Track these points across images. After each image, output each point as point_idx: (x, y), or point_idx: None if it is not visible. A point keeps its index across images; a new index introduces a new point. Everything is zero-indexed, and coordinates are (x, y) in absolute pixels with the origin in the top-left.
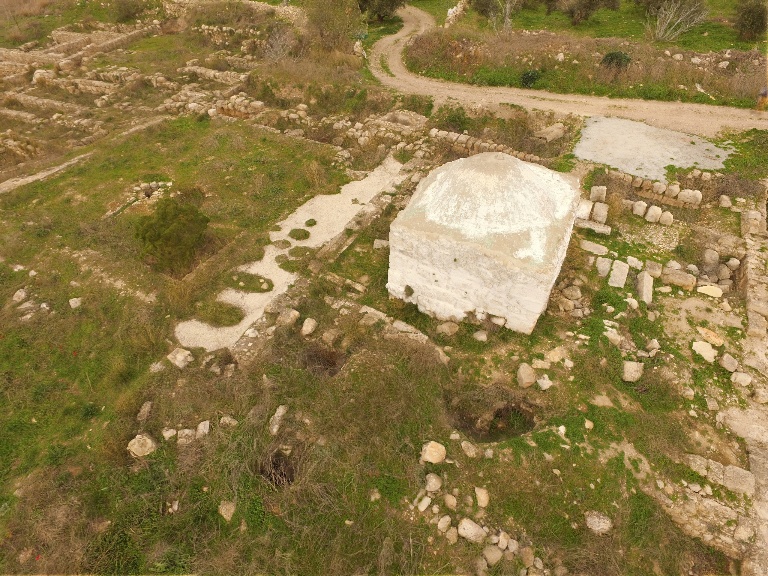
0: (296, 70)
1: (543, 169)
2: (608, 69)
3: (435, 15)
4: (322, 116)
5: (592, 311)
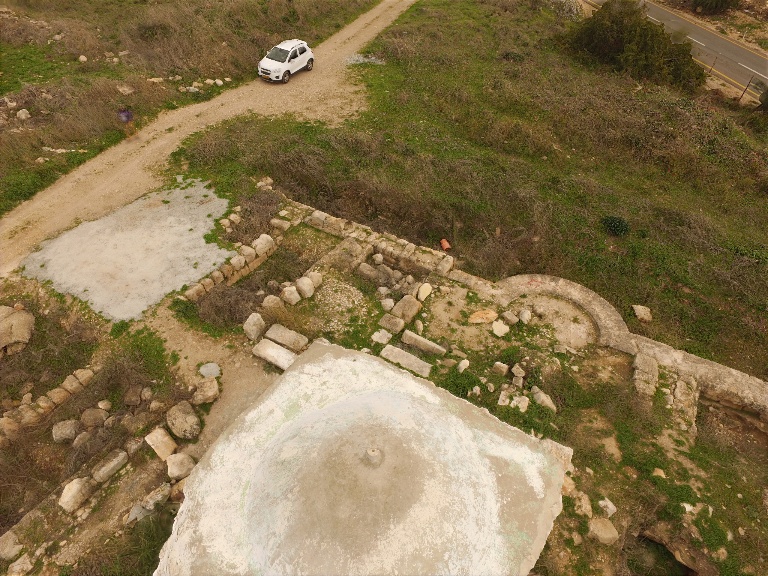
0: None
1: (285, 382)
2: None
3: None
4: None
5: None
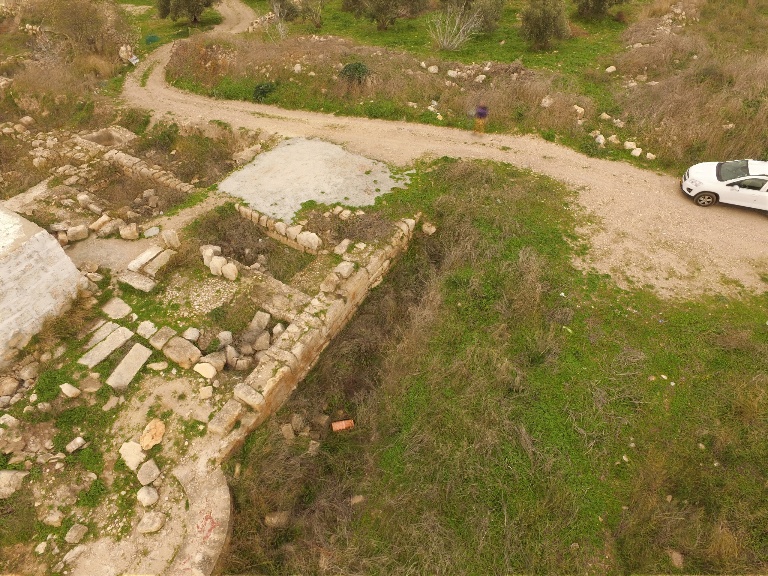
0: (37, 78)
1: (11, 218)
2: (341, 83)
3: None
4: (43, 130)
5: (22, 398)
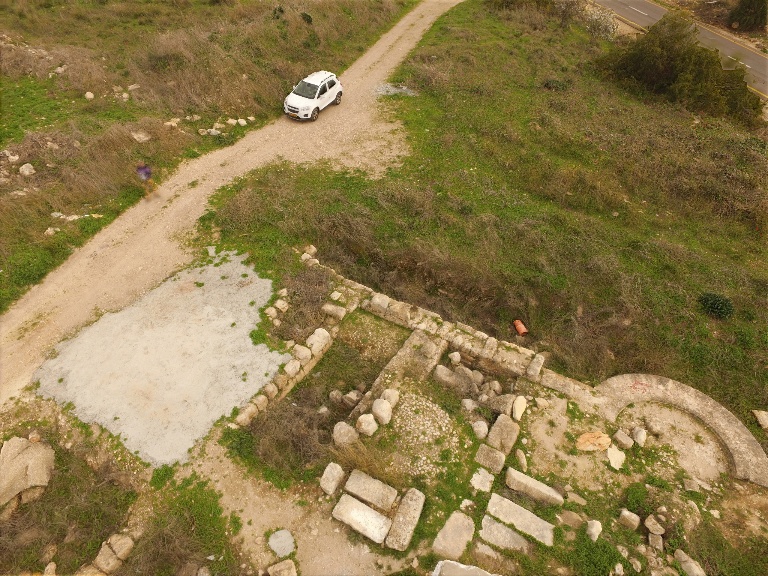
0: None
1: None
2: None
3: None
4: None
5: None
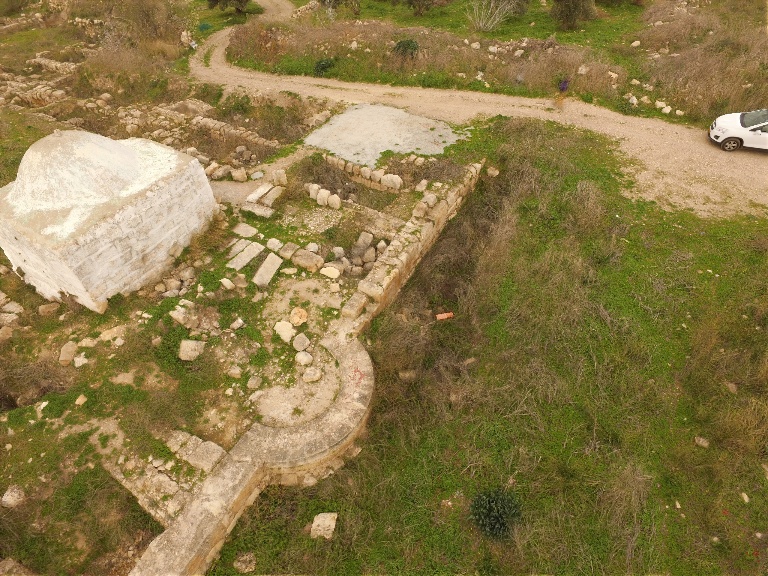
0: (110, 60)
1: (167, 150)
2: (395, 57)
3: (299, 7)
4: (122, 105)
5: (189, 291)
